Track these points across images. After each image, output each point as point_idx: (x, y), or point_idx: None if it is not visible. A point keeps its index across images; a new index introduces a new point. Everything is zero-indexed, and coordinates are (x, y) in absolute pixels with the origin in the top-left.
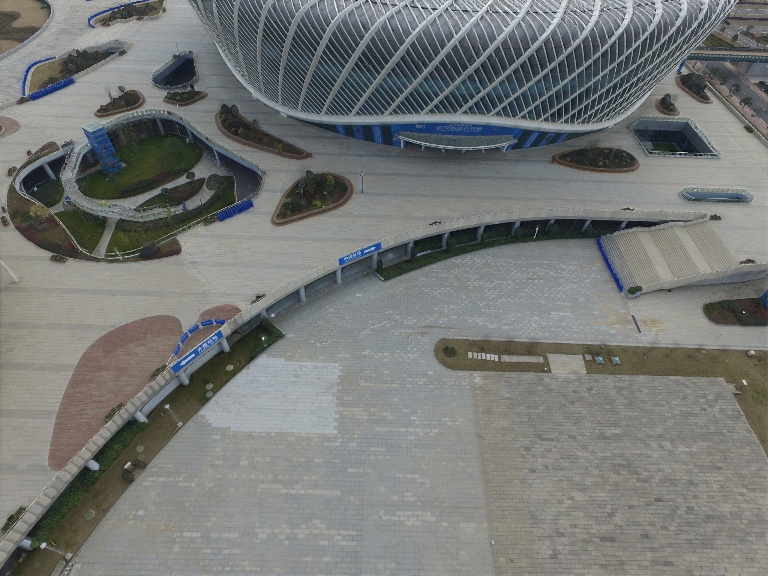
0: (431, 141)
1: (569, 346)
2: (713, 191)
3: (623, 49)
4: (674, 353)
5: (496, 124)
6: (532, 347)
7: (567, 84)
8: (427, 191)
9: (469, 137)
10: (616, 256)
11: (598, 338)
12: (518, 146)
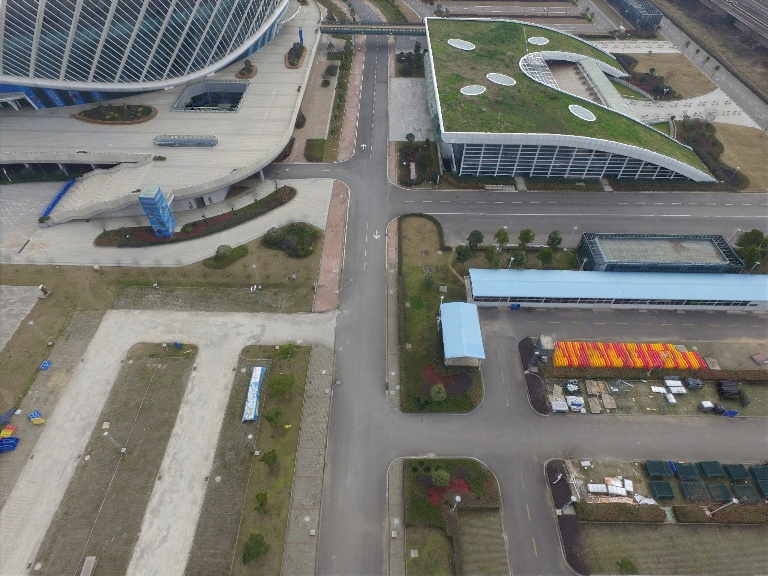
0: None
1: None
2: (189, 138)
3: (29, 5)
4: (27, 268)
5: None
6: None
7: (6, 40)
8: None
9: None
10: (69, 194)
11: None
12: (51, 104)
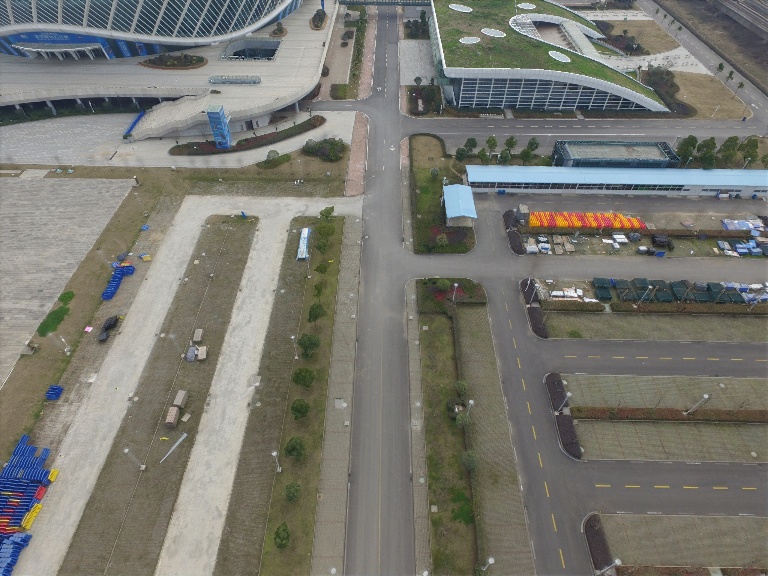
0: (32, 47)
1: (49, 166)
2: (237, 78)
3: None
4: (120, 169)
5: (69, 31)
6: (21, 166)
7: None
8: (19, 81)
9: (64, 44)
10: (143, 121)
11: (75, 162)
12: (120, 55)
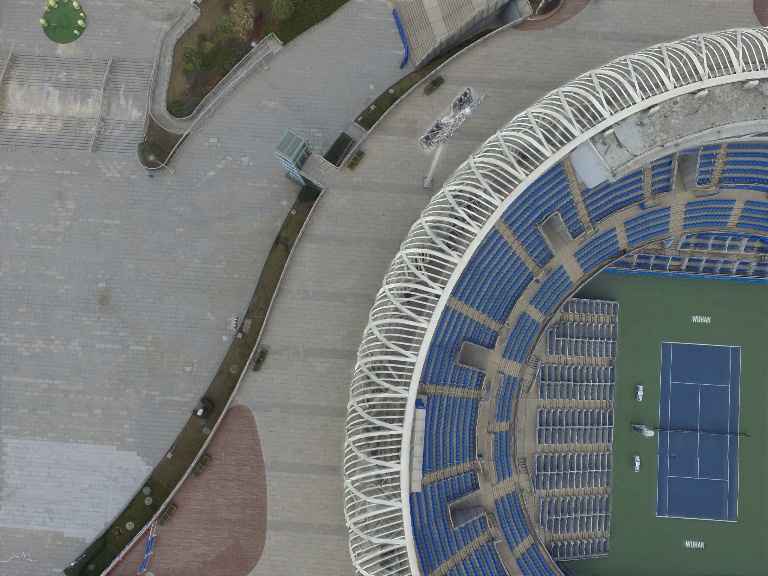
0: None
1: None
2: None
3: None
4: None
5: None
6: None
7: None
8: None
9: None
10: None
11: None
12: None
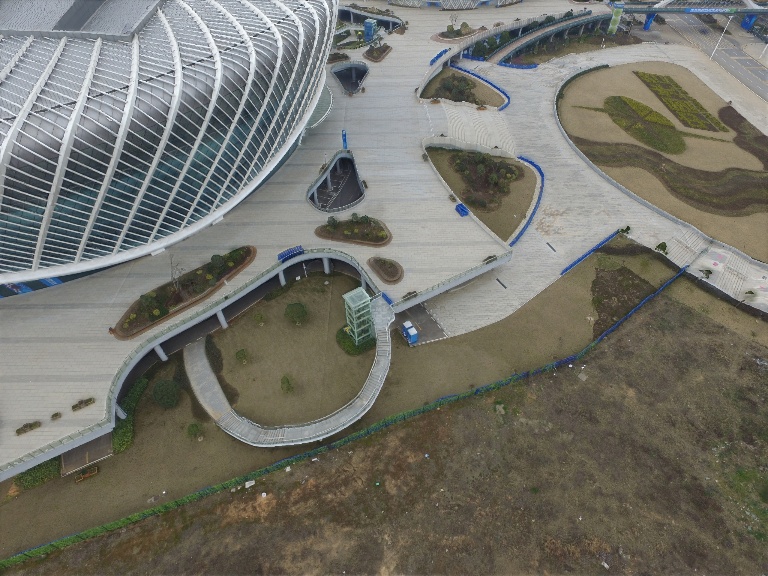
0: None
1: None
2: None
3: None
4: None
5: None
6: None
7: None
8: None
9: None
10: None
11: None
12: None
